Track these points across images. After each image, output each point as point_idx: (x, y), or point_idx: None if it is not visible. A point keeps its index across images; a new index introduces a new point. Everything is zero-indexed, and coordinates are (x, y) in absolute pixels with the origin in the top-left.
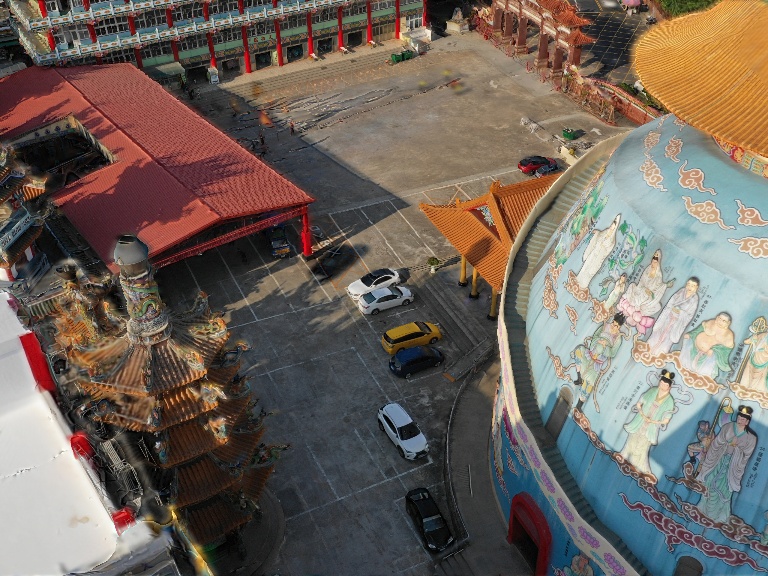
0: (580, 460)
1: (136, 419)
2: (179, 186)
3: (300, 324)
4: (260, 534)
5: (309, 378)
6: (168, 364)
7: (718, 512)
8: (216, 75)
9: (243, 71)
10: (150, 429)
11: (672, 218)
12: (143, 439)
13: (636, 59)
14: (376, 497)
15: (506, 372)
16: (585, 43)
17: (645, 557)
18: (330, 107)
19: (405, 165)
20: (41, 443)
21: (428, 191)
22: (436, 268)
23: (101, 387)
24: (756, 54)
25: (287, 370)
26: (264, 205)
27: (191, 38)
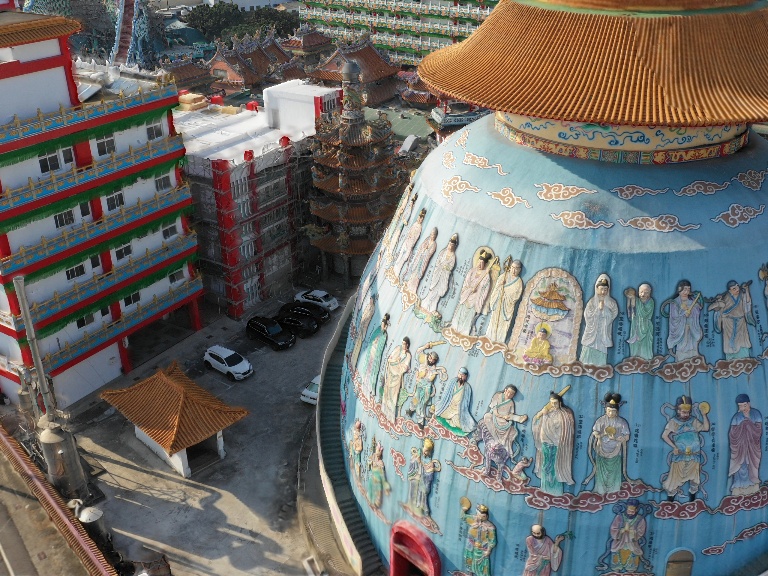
0: None
1: None
2: None
3: None
4: None
5: None
6: None
7: None
8: None
9: None
10: None
11: None
12: None
13: None
14: None
15: None
16: None
17: None
18: None
19: None
20: None
21: None
22: None
23: None
24: None
25: None
26: None
27: None
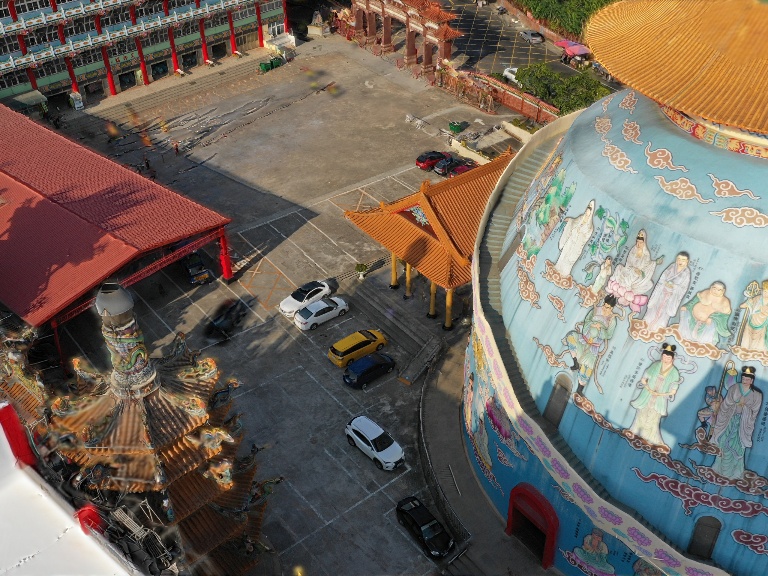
0: (586, 442)
1: (136, 479)
2: (83, 223)
3: (239, 350)
4: (257, 575)
5: (263, 405)
6: (164, 415)
7: (733, 470)
8: (80, 100)
9: (107, 94)
10: (156, 488)
11: (649, 198)
12: (147, 500)
13: (592, 49)
14: (365, 514)
15: (497, 368)
16: (454, 37)
17: (662, 524)
18: (209, 123)
19: (303, 174)
20: (37, 525)
21: (333, 198)
22: (363, 274)
23: (96, 452)
24: (719, 36)
25: (238, 400)
26: (180, 232)
27: (48, 64)
